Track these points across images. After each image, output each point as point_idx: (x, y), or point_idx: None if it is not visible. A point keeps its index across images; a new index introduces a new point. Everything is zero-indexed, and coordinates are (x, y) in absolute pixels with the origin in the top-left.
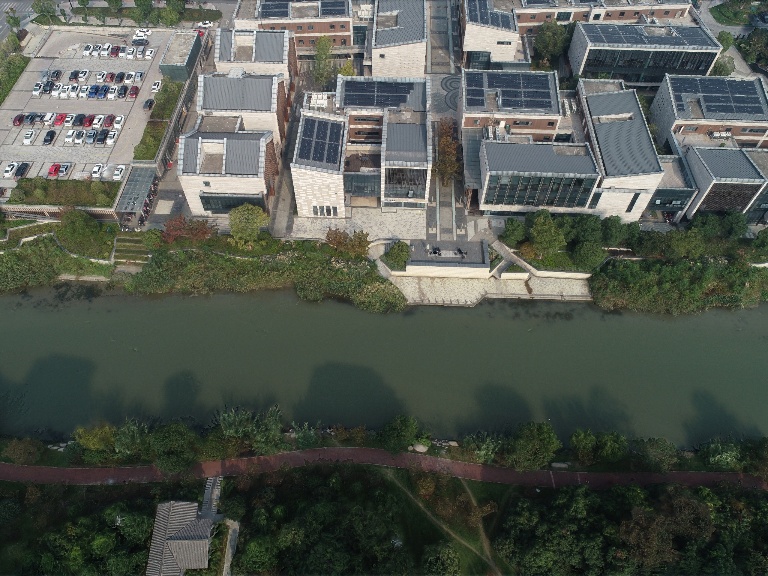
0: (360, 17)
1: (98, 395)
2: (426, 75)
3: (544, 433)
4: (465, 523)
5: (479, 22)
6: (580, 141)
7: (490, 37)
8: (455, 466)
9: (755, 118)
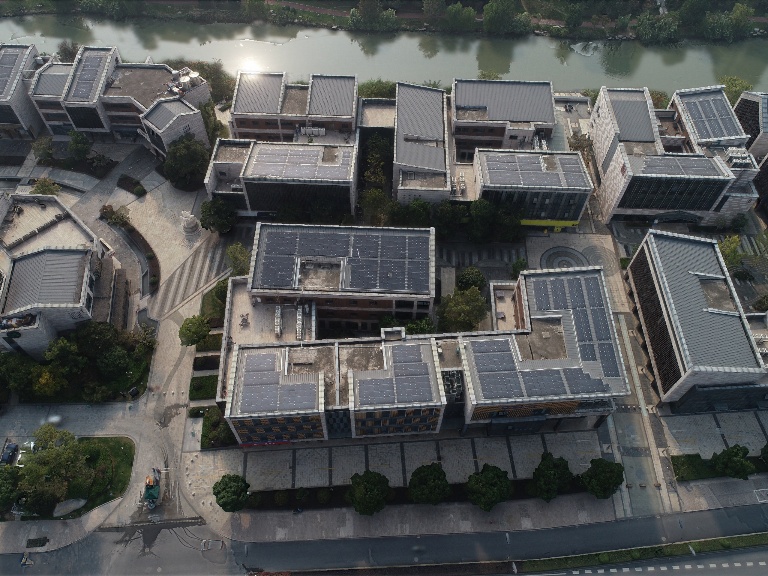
0: (765, 335)
1: (760, 54)
2: (624, 309)
3: (496, 6)
4: (530, 1)
5: (583, 280)
6: (451, 152)
7: None
8: (536, 21)
9: (272, 146)
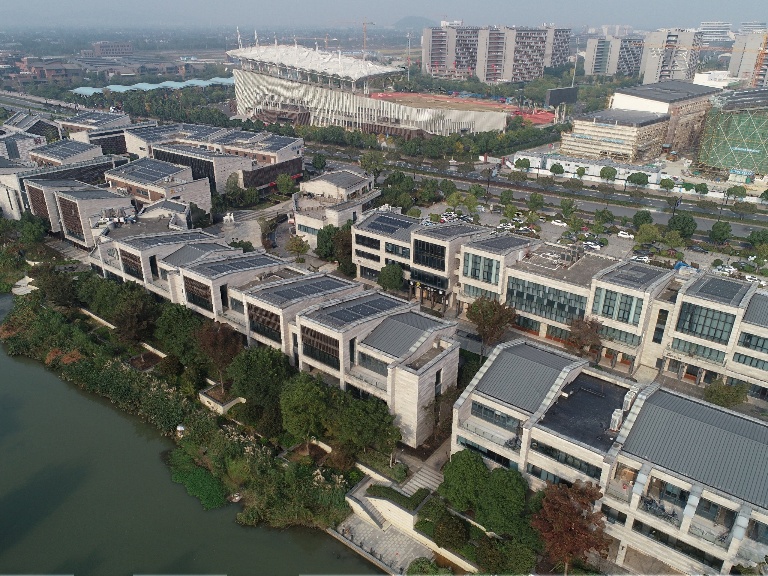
0: None
1: None
2: None
3: None
4: None
5: None
6: None
7: (135, 143)
8: None
9: (144, 182)
